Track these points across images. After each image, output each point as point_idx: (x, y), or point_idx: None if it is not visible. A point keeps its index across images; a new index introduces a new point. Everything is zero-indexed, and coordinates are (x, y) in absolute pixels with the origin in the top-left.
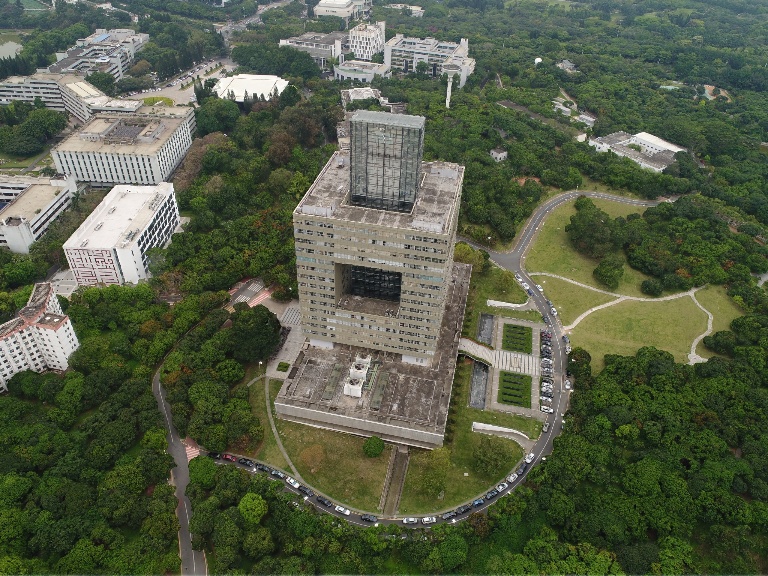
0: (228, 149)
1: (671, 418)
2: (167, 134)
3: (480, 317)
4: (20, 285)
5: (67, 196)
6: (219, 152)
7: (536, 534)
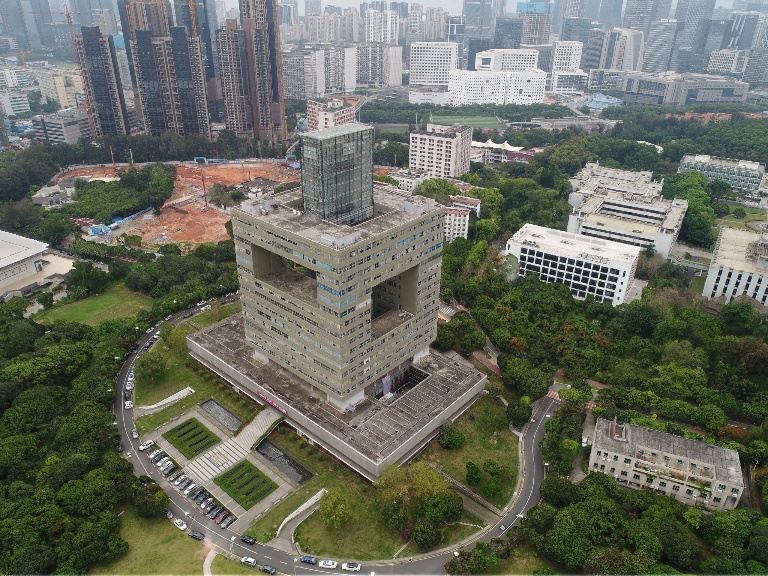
0: None
1: (1, 505)
2: None
3: (309, 469)
4: None
5: None
6: None
7: (86, 371)
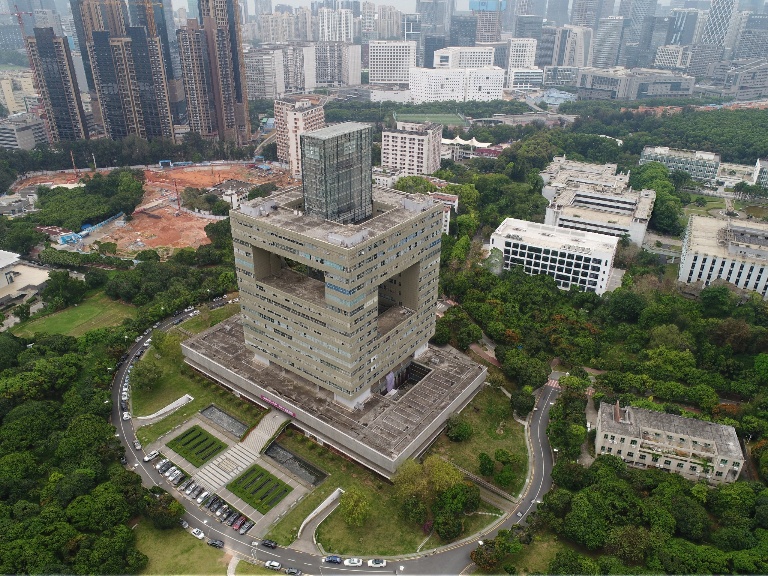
0: (767, 315)
1: (8, 526)
2: (764, 263)
3: (321, 470)
4: None
5: (624, 234)
6: (754, 308)
7: (77, 384)
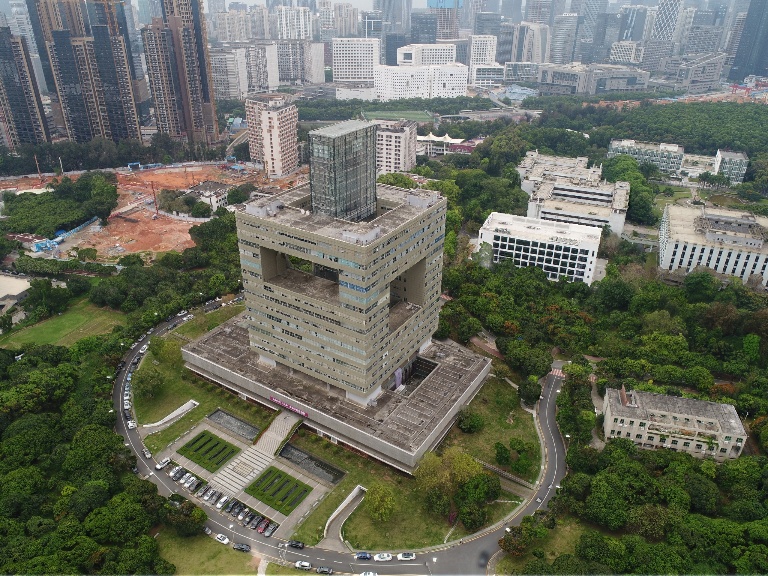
0: (748, 298)
1: (25, 543)
2: None
3: (339, 468)
4: (482, 223)
5: None
6: (735, 292)
7: (75, 395)
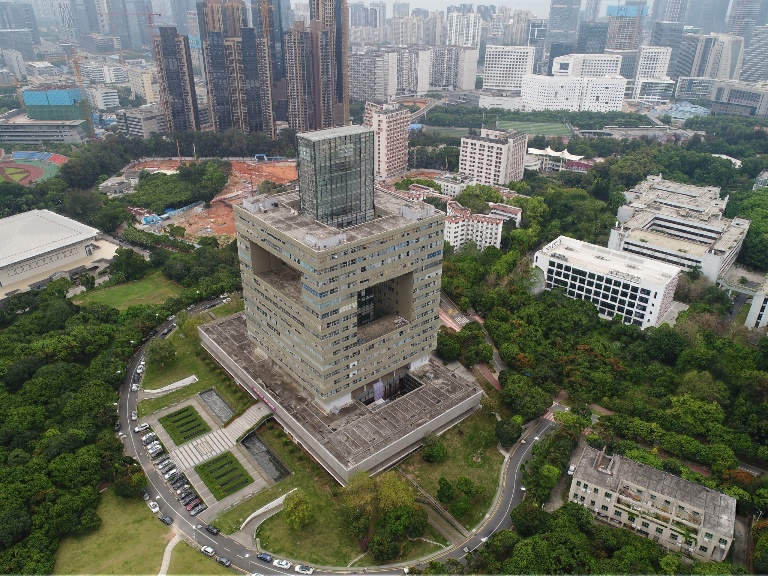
0: None
1: None
2: None
3: (287, 467)
4: None
5: None
6: None
7: (104, 352)
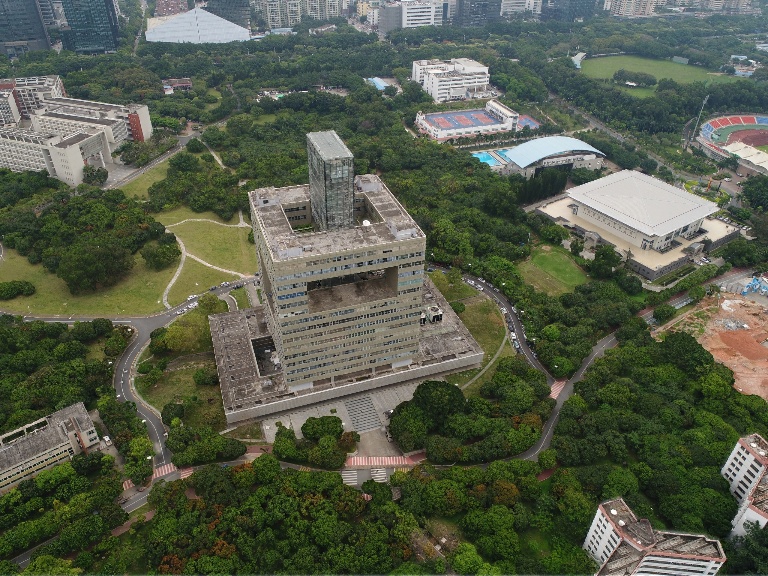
0: None
1: None
2: None
3: None
4: None
5: None
6: None
7: None
